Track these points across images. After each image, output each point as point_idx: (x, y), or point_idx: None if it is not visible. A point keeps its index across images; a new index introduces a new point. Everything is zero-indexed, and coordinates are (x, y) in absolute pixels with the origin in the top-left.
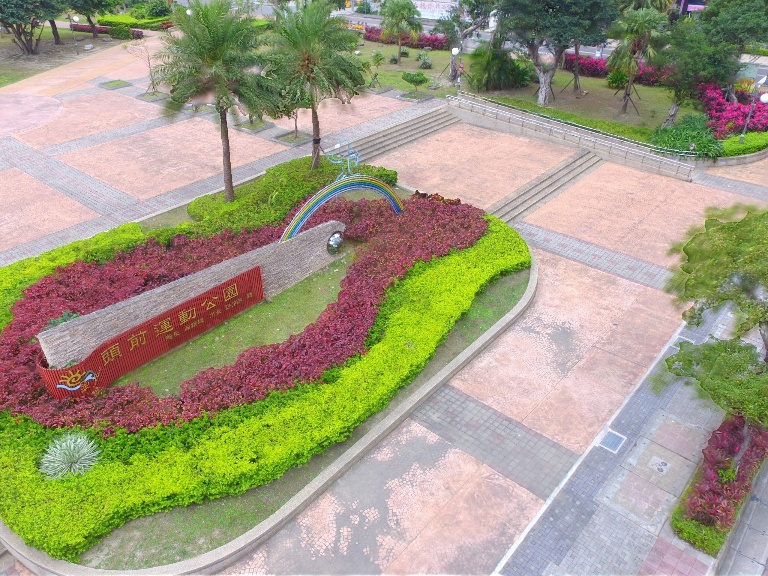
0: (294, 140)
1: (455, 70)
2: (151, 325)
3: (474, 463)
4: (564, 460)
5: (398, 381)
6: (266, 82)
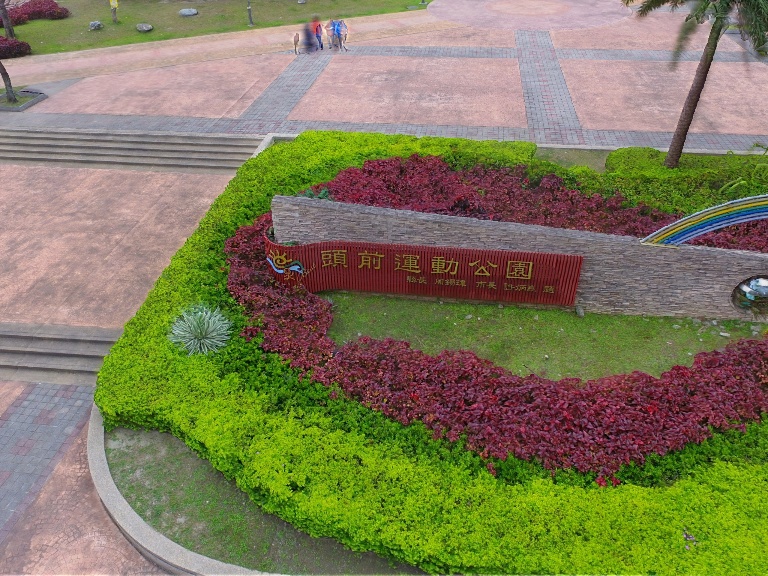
0: None
1: None
2: (393, 252)
3: None
4: None
5: (598, 574)
6: None
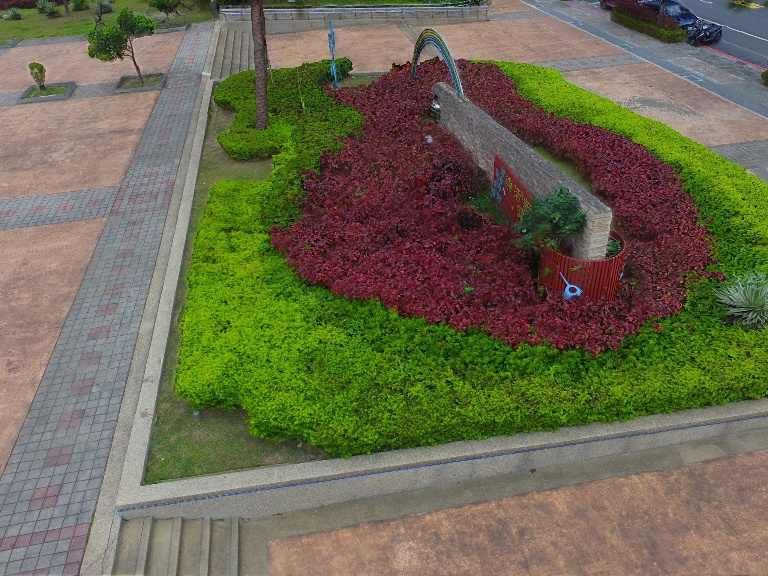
0: (145, 84)
1: None
2: None
3: None
4: None
5: None
6: None
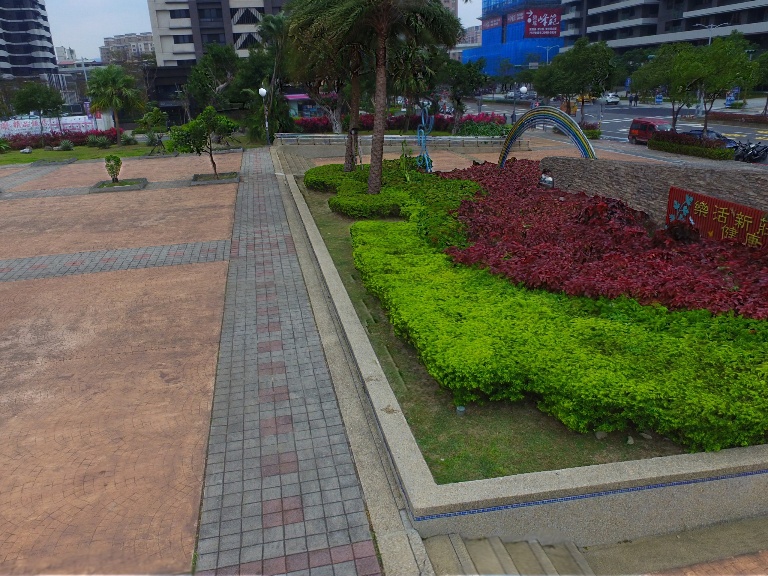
0: None
1: None
2: None
3: None
4: None
5: None
6: None
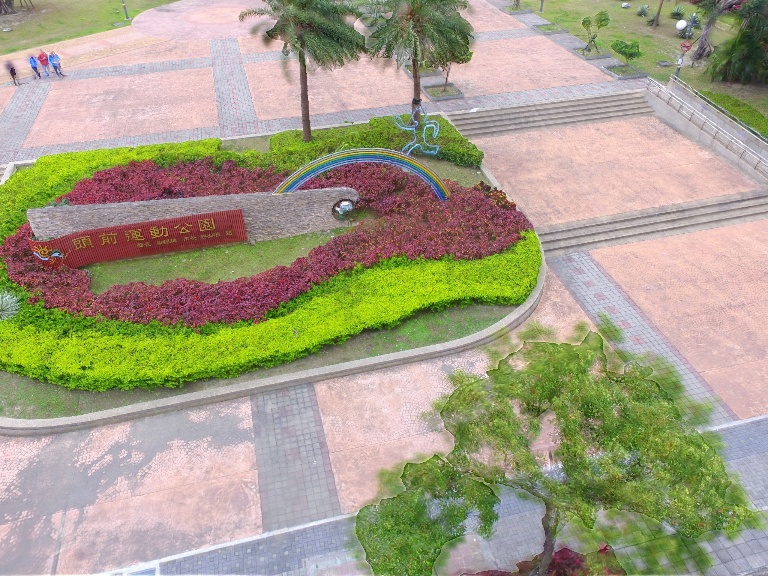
0: (440, 94)
1: (702, 47)
2: (122, 230)
3: (250, 464)
4: (323, 509)
5: (252, 359)
6: (337, 33)
